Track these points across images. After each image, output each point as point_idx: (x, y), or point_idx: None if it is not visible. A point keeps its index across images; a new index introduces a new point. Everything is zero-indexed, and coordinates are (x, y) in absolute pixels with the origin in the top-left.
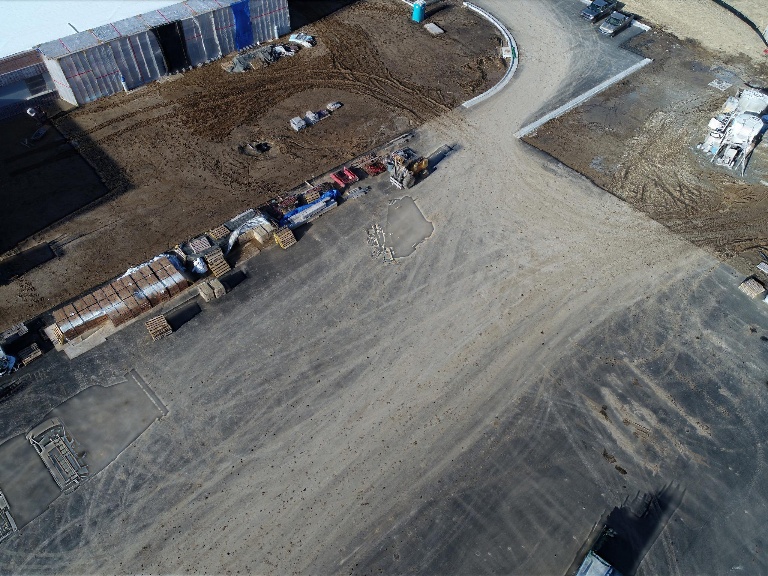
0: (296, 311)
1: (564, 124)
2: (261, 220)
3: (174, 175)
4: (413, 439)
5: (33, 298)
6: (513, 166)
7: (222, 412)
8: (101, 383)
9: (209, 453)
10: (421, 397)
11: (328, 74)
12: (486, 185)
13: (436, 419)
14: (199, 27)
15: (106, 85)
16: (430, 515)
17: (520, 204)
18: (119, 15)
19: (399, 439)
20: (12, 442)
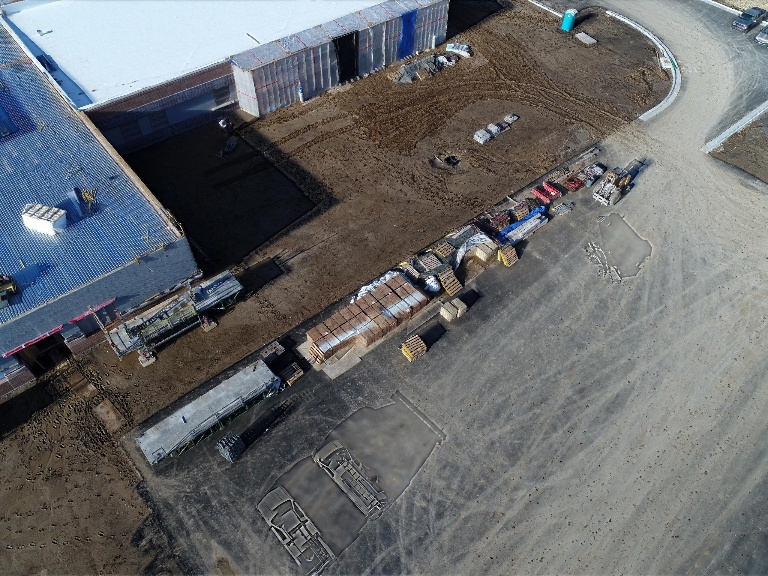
0: (541, 332)
1: (748, 138)
2: (483, 237)
3: (374, 189)
4: (702, 469)
5: (275, 315)
6: (711, 182)
7: (500, 437)
8: (370, 405)
9: (501, 480)
10: (697, 425)
11: (494, 85)
12: (690, 202)
13: (719, 448)
14: (372, 37)
15: (285, 96)
16: (745, 550)
17: (731, 222)
18: (293, 25)
19: (688, 469)
20: (302, 465)
